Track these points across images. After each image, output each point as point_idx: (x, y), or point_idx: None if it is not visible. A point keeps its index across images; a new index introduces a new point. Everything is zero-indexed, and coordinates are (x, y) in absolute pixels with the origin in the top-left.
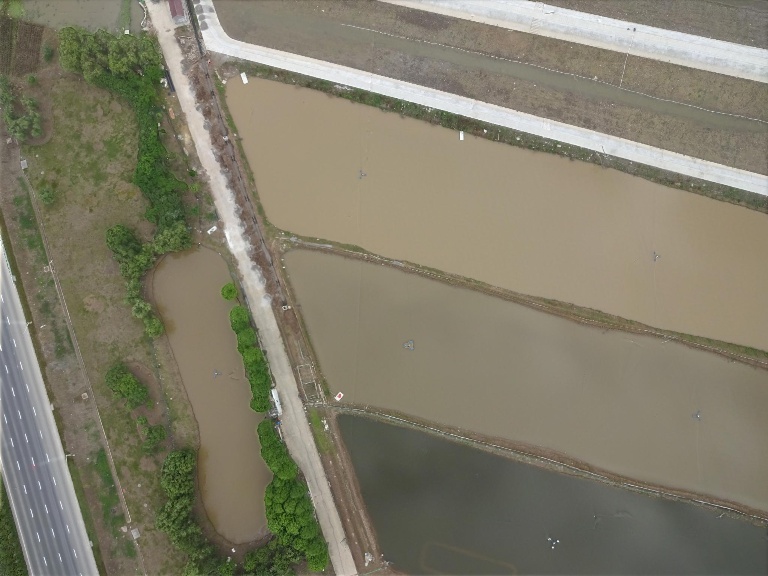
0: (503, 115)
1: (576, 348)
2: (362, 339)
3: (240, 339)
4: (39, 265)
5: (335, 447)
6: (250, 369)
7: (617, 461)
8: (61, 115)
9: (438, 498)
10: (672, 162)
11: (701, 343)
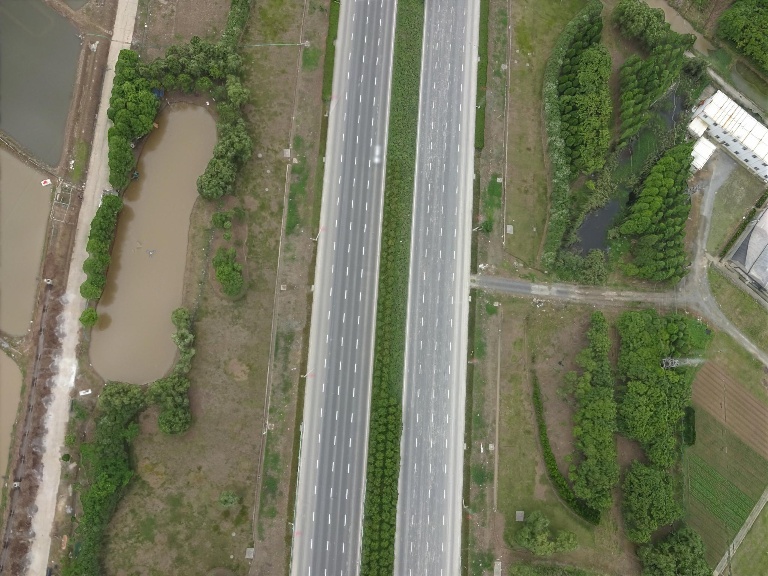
0: None
1: None
2: None
3: (96, 265)
4: (277, 434)
5: (74, 143)
6: (99, 233)
7: None
8: None
9: (0, 60)
10: None
11: None
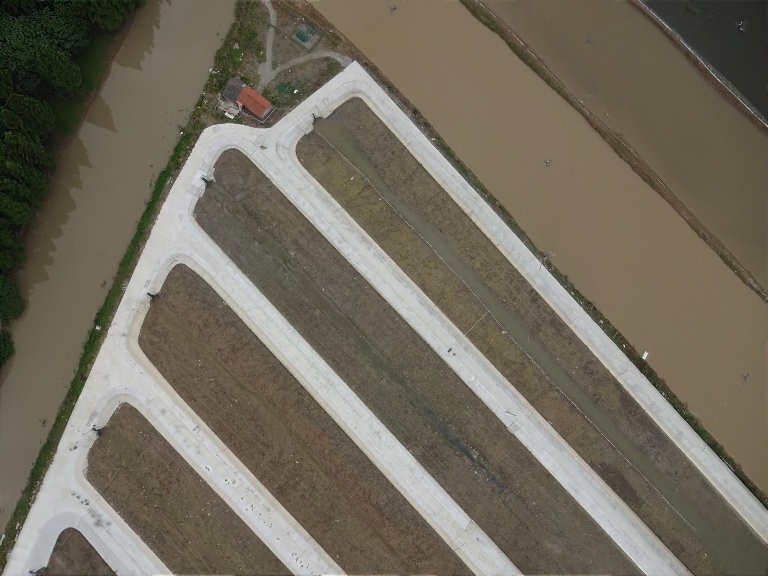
0: (604, 349)
1: (649, 137)
2: None
3: None
4: None
5: None
6: None
7: (664, 47)
8: None
9: None
10: (493, 222)
11: (556, 83)
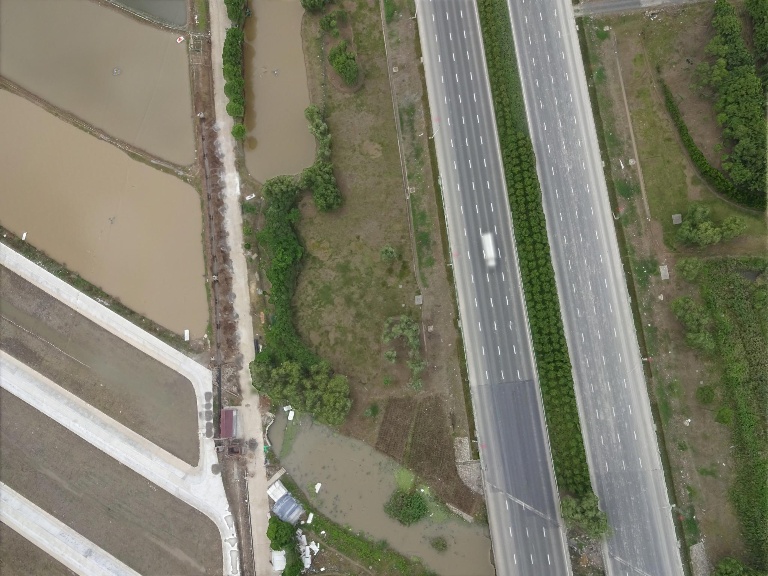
0: None
1: (0, 52)
2: (153, 84)
3: (234, 85)
4: (419, 195)
5: (194, 1)
6: (230, 59)
7: None
8: (372, 343)
9: None
10: None
11: None
